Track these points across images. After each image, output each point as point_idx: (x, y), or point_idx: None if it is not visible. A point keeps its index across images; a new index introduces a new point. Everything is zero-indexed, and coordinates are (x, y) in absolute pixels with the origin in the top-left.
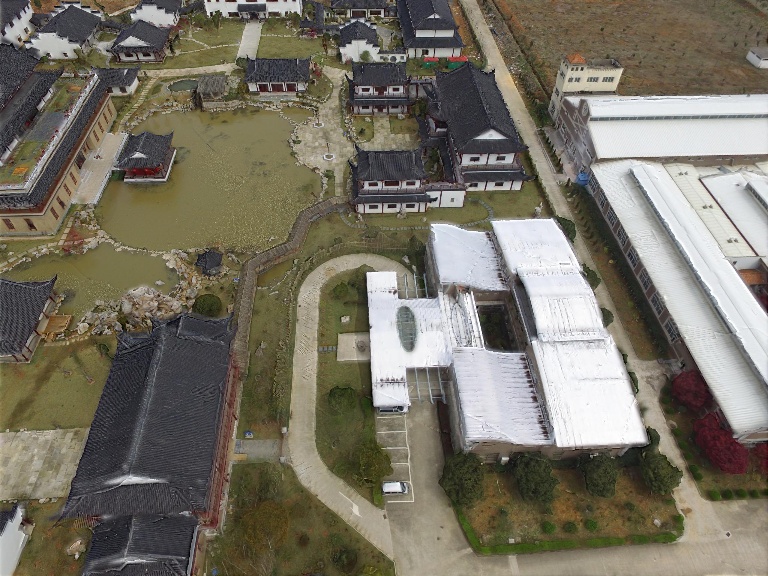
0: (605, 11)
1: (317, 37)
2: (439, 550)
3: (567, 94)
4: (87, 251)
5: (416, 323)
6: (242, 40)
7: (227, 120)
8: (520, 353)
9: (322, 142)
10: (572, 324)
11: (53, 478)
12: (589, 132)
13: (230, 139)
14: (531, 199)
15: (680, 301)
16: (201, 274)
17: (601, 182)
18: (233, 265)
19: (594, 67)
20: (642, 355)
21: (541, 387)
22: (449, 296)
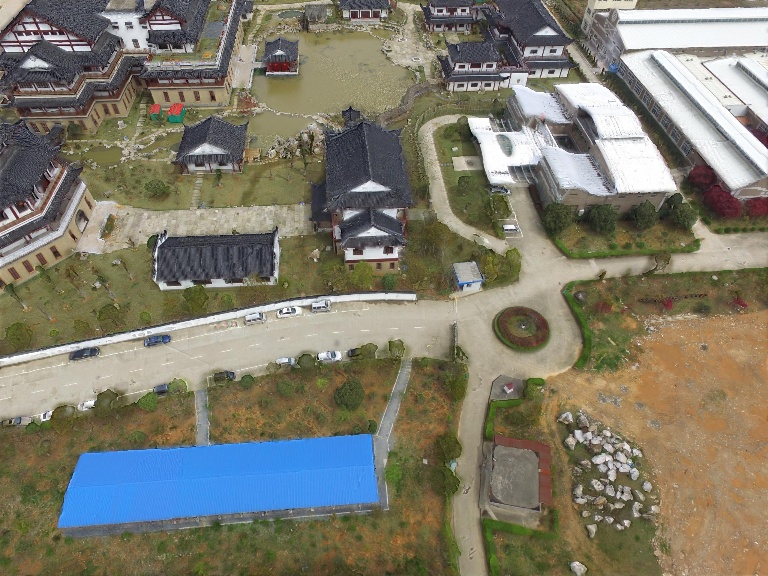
0: None
1: None
2: (544, 258)
3: (598, 11)
4: (255, 115)
5: (511, 141)
6: None
7: (330, 38)
8: (585, 154)
9: (408, 51)
10: (621, 130)
11: (283, 227)
12: (618, 32)
13: (336, 50)
14: None
15: (692, 128)
16: (344, 127)
17: (629, 65)
18: None
19: None
20: None
21: (603, 168)
22: (530, 128)
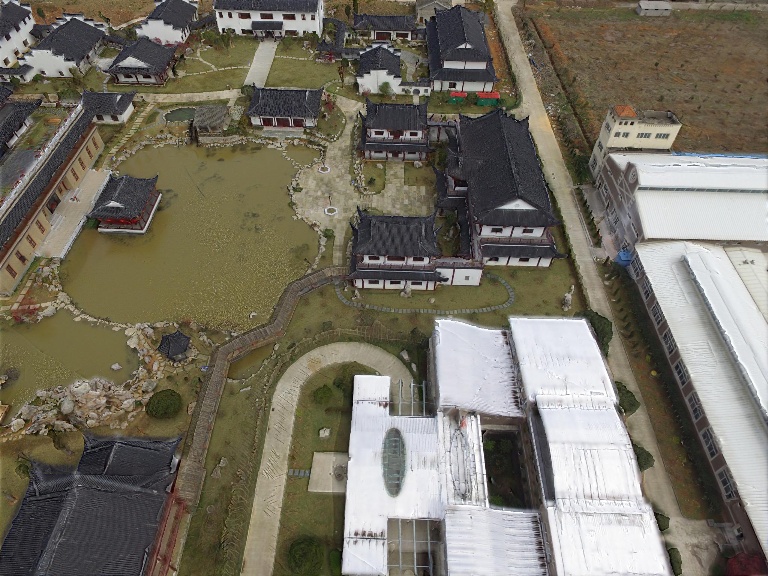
0: (661, 41)
1: (335, 61)
2: None
3: (612, 150)
4: (42, 319)
5: (406, 457)
6: (253, 62)
7: (224, 158)
8: (532, 513)
9: (326, 191)
10: (601, 487)
11: None
12: (636, 204)
13: (224, 182)
14: (561, 279)
15: (741, 448)
16: (165, 358)
17: (647, 268)
18: (204, 348)
19: (647, 121)
20: (687, 511)
21: (555, 571)
22: (450, 419)
